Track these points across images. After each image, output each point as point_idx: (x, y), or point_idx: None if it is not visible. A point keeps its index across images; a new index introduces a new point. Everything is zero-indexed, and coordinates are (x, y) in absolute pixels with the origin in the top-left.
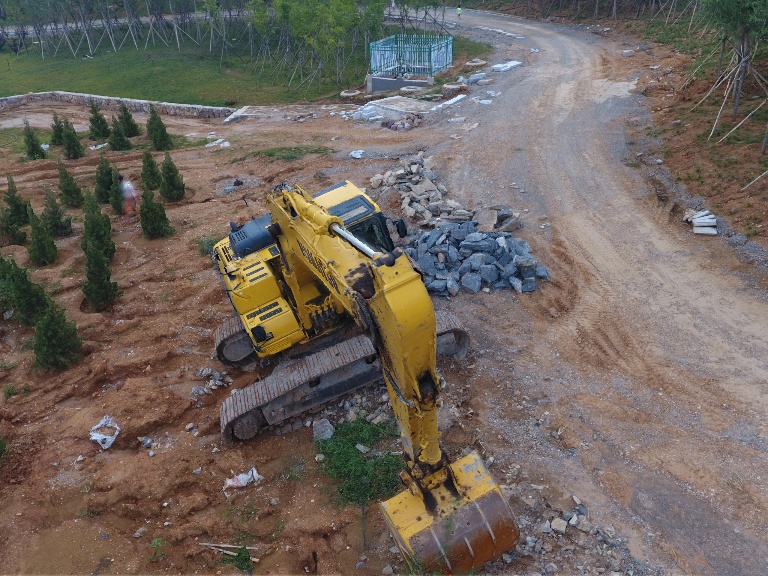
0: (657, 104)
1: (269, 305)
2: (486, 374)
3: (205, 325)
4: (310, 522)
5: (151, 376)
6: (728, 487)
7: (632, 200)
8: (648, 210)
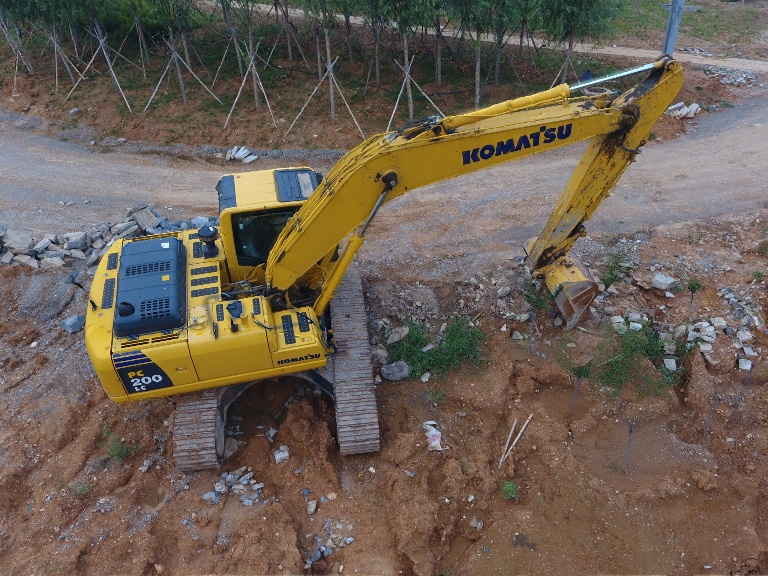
0: (17, 106)
1: (284, 323)
2: (375, 271)
3: (84, 506)
4: (499, 383)
5: (174, 569)
6: (505, 219)
7: (169, 168)
8: (193, 167)
